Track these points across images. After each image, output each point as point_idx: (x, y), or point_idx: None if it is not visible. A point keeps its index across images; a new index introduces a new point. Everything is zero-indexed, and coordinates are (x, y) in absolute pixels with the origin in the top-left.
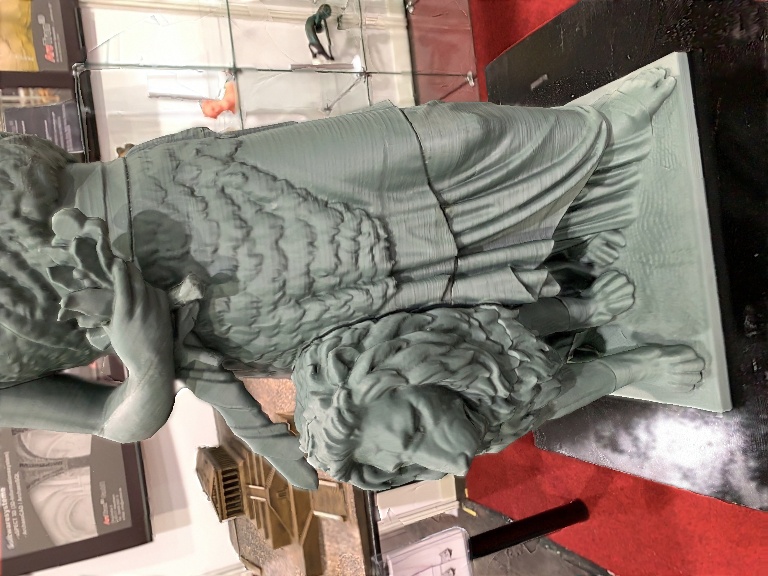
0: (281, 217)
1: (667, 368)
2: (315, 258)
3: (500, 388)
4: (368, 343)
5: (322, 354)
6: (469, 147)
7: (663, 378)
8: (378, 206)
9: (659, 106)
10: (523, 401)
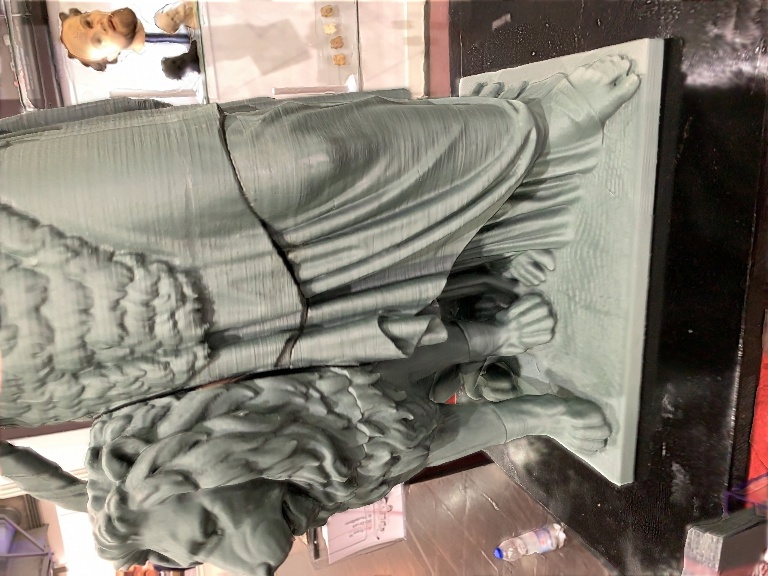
0: (45, 275)
1: (568, 428)
2: (91, 329)
3: (334, 474)
4: (162, 429)
5: (106, 437)
6: (315, 184)
7: (563, 437)
8: (187, 257)
9: (615, 110)
10: (373, 475)
